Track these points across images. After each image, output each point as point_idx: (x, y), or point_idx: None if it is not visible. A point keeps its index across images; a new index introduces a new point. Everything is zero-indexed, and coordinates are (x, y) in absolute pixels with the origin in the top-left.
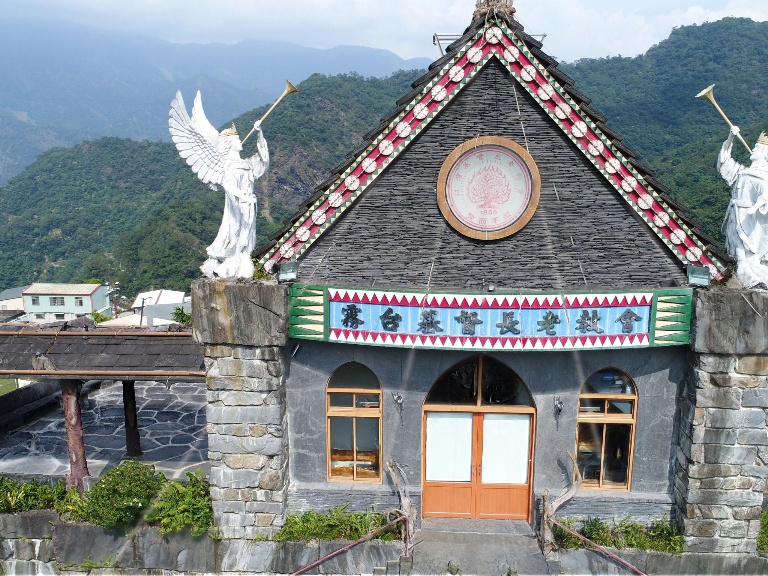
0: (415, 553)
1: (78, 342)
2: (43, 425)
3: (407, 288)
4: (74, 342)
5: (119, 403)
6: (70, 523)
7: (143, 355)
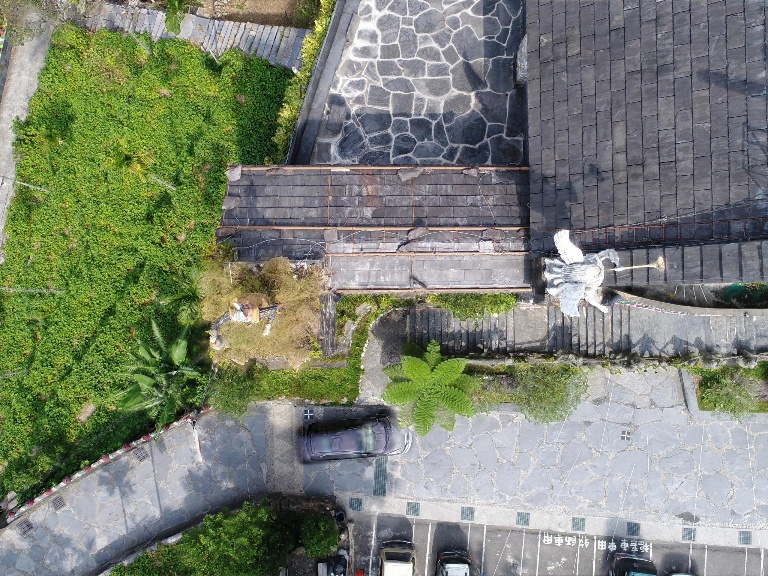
0: (632, 308)
1: (430, 259)
2: (327, 152)
3: (691, 308)
4: (427, 259)
5: (367, 103)
6: (429, 303)
7: (481, 270)
